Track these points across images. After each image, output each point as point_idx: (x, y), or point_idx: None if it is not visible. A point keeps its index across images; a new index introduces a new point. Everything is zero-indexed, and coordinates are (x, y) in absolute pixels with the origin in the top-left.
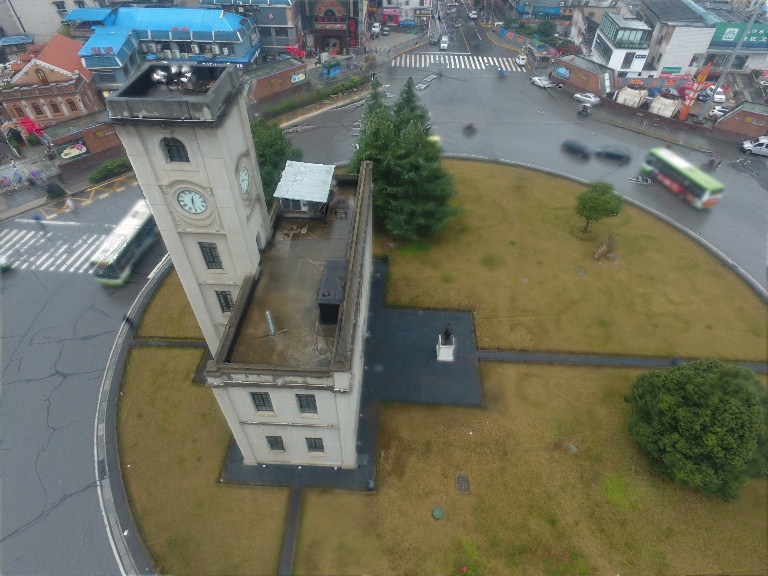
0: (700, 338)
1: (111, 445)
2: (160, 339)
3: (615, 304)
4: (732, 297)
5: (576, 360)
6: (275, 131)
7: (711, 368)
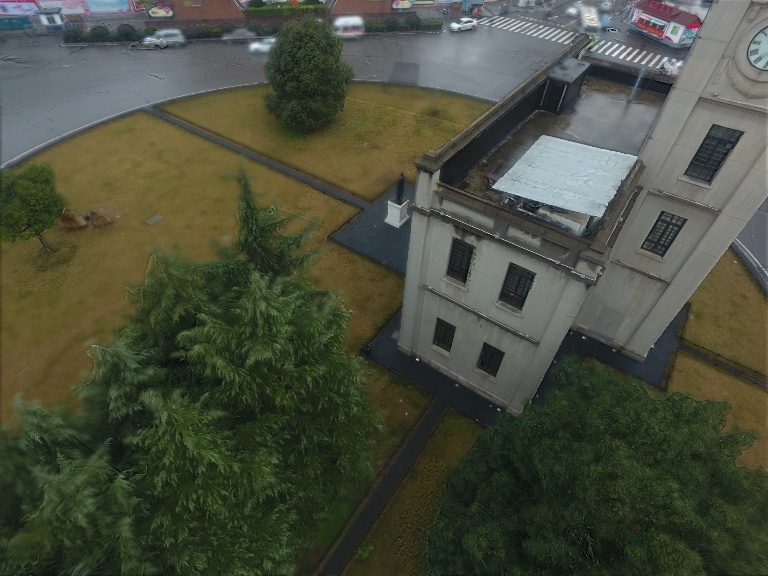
0: (175, 143)
1: (765, 286)
2: (760, 385)
3: (187, 182)
4: (84, 148)
5: (290, 172)
6: (613, 468)
7: (298, 38)
